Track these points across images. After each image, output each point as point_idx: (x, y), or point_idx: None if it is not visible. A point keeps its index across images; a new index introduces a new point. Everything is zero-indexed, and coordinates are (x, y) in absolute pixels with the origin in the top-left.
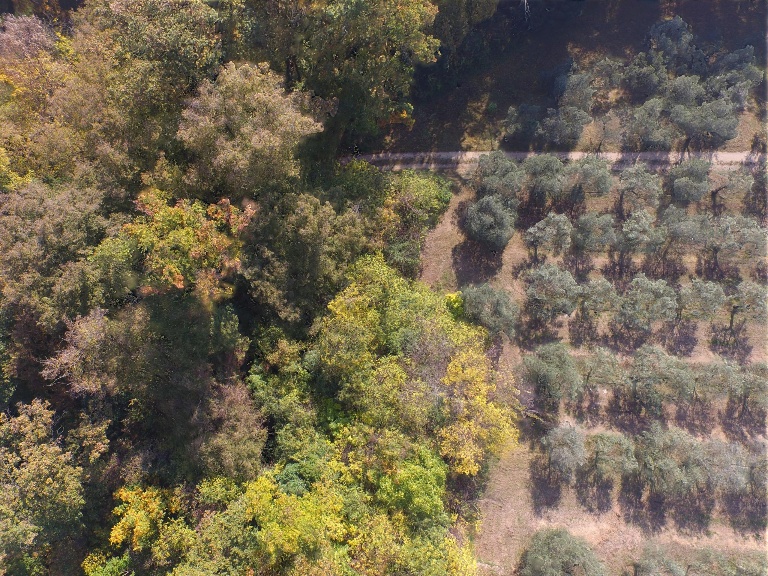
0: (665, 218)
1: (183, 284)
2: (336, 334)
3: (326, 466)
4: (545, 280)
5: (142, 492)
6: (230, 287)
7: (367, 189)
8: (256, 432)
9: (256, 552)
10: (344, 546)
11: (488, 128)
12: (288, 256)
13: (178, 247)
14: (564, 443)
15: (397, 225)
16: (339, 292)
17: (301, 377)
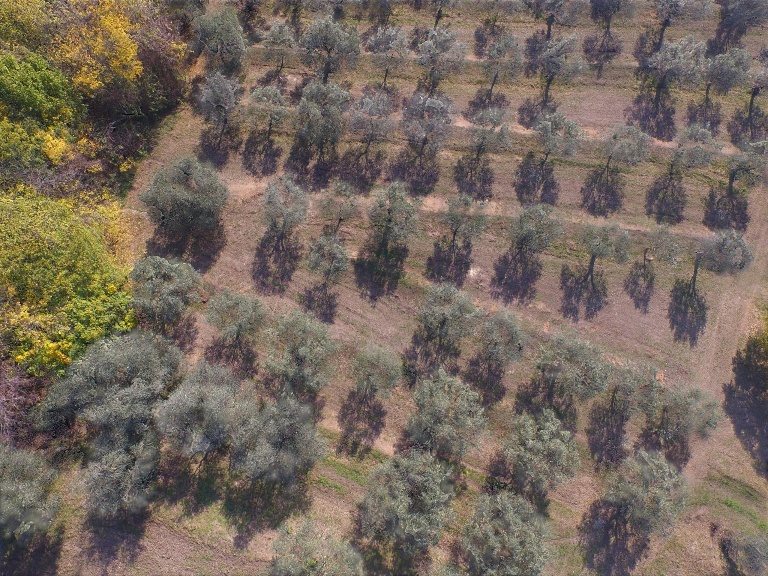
0: None
1: None
2: None
3: None
4: None
5: None
6: None
7: None
8: None
9: None
10: None
11: None
12: None
13: None
14: None
15: None
16: None
17: None
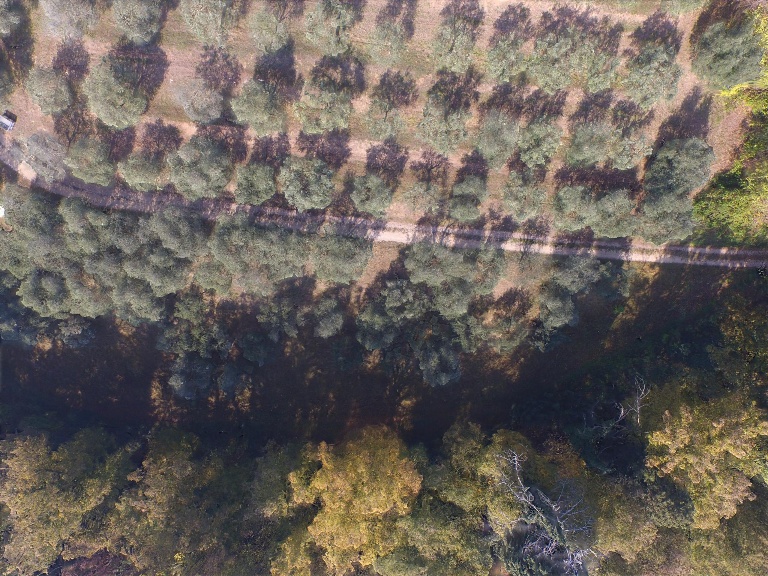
0: None
1: None
2: None
3: None
4: None
5: None
6: None
7: None
8: None
9: None
10: None
11: (627, 287)
12: None
13: None
14: None
15: None
16: None
17: None
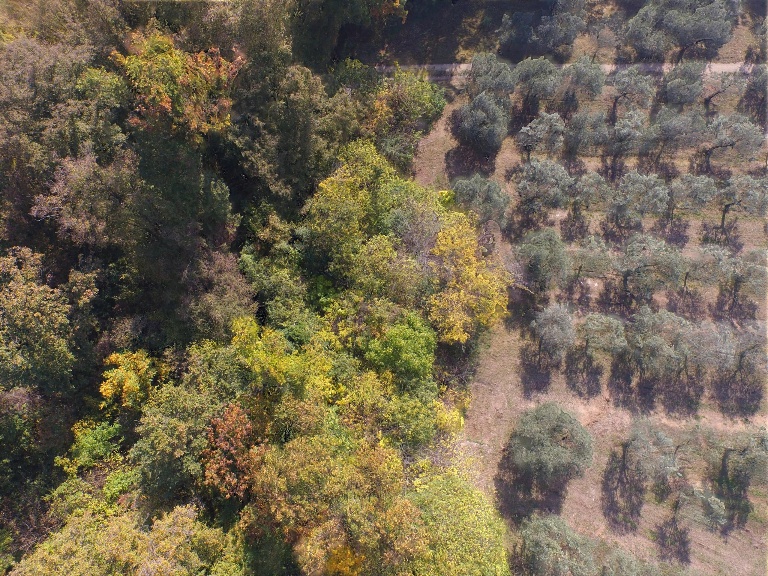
0: (658, 119)
1: (171, 106)
2: (326, 202)
3: (316, 335)
4: (537, 172)
5: (132, 354)
6: (221, 162)
7: (360, 78)
8: (246, 303)
9: (243, 387)
10: (332, 406)
11: (482, 41)
12: (279, 132)
13: (166, 69)
14: (554, 321)
15: (390, 122)
16: (330, 174)
17: (292, 258)
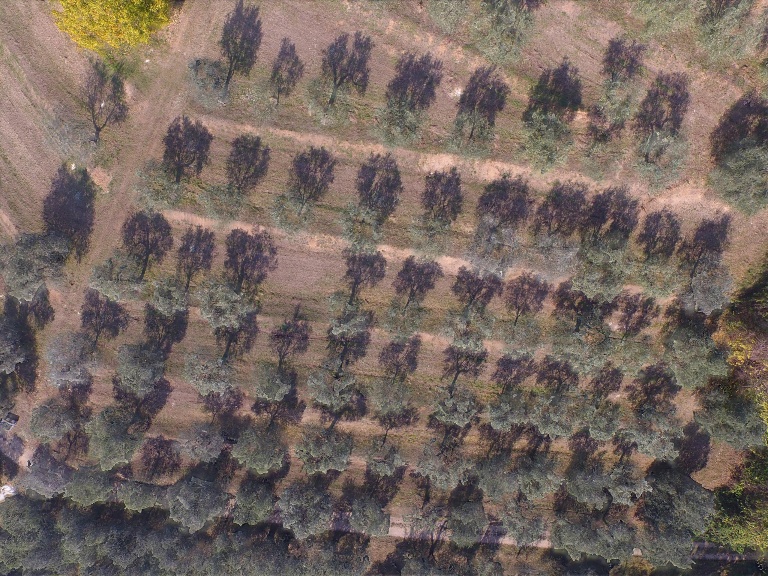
0: None
1: None
2: None
3: None
4: None
5: None
6: None
7: None
8: None
9: None
10: None
11: None
12: None
13: None
14: None
15: None
16: None
17: None
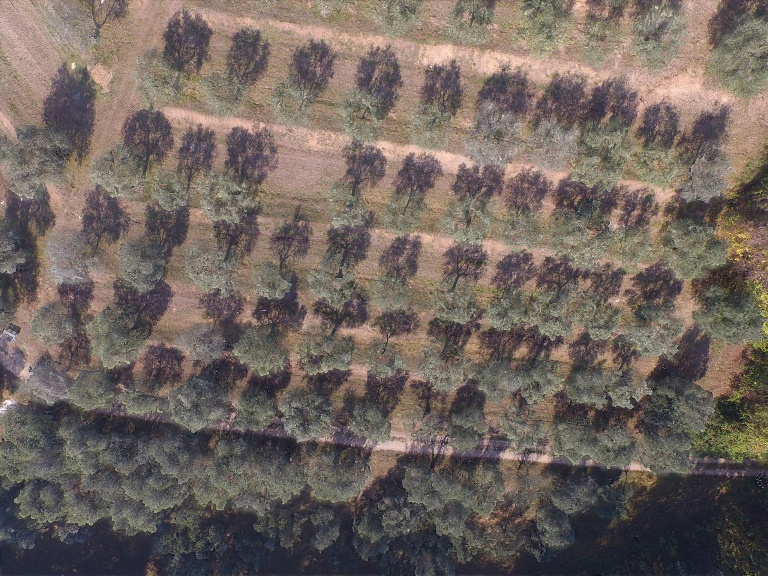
0: None
1: None
2: None
3: None
4: None
5: None
6: None
7: None
8: None
9: None
10: None
11: None
12: None
13: None
14: (718, 181)
15: None
16: None
17: None
